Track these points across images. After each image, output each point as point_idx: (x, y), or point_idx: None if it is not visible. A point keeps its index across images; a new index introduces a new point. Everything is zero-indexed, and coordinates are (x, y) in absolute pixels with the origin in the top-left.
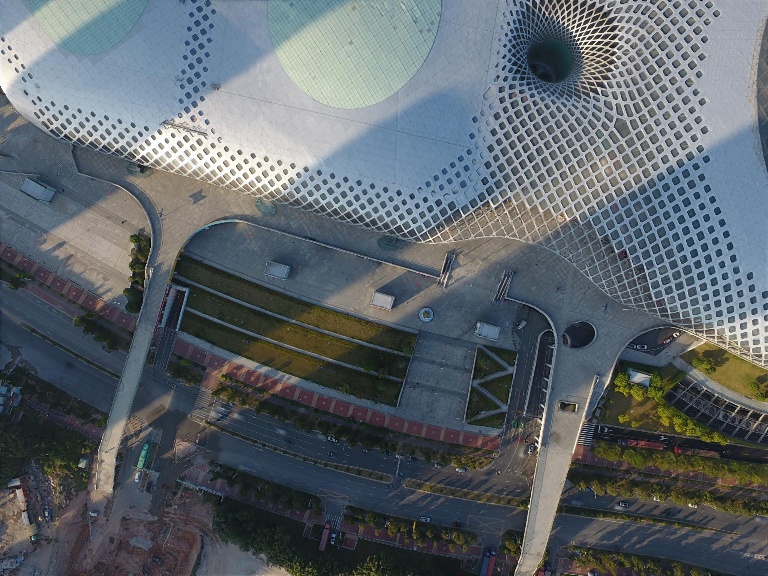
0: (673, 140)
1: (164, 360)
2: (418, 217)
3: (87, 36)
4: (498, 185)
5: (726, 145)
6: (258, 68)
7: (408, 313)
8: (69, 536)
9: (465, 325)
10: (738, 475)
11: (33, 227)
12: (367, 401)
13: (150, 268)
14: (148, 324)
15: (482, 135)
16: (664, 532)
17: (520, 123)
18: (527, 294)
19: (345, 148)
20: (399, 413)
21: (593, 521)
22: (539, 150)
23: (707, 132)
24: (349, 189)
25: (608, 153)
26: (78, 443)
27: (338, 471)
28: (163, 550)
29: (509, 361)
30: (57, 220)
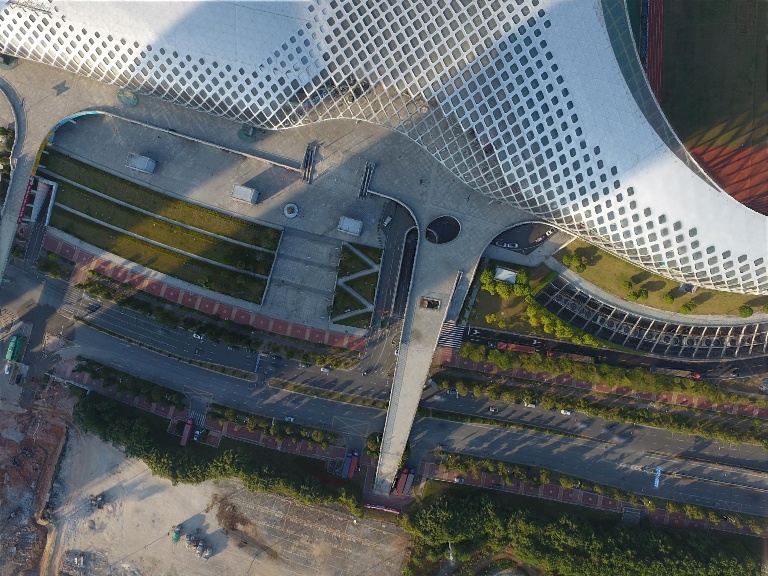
0: (514, 6)
1: (35, 255)
2: (264, 98)
3: None
4: (340, 61)
5: (567, 7)
6: None
7: (273, 209)
8: None
9: (330, 222)
10: (607, 377)
11: None
12: (232, 298)
13: (14, 159)
14: (12, 215)
15: (321, 7)
16: (535, 439)
17: None
18: (389, 187)
19: (185, 24)
20: (264, 311)
21: (461, 426)
22: (381, 23)
23: None
24: (193, 69)
25: (450, 23)
26: None
27: (203, 368)
28: (34, 443)
29: (375, 259)
30: None
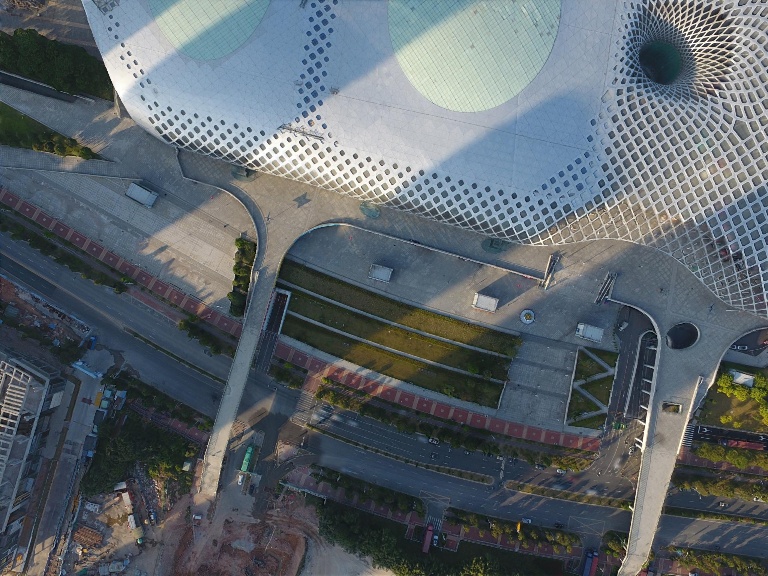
0: None
1: (265, 363)
2: (531, 220)
3: (208, 41)
4: (614, 187)
5: None
6: (377, 72)
7: (509, 315)
8: (173, 539)
9: (566, 327)
10: None
11: (135, 231)
12: (468, 403)
13: (256, 272)
14: (254, 328)
15: (600, 138)
16: (764, 532)
17: (638, 125)
18: (630, 296)
19: (462, 151)
20: (500, 415)
21: (693, 521)
22: (656, 152)
23: None
24: (464, 192)
25: (727, 155)
26: (182, 446)
27: (439, 473)
28: (265, 552)
29: (610, 362)
30: (159, 224)
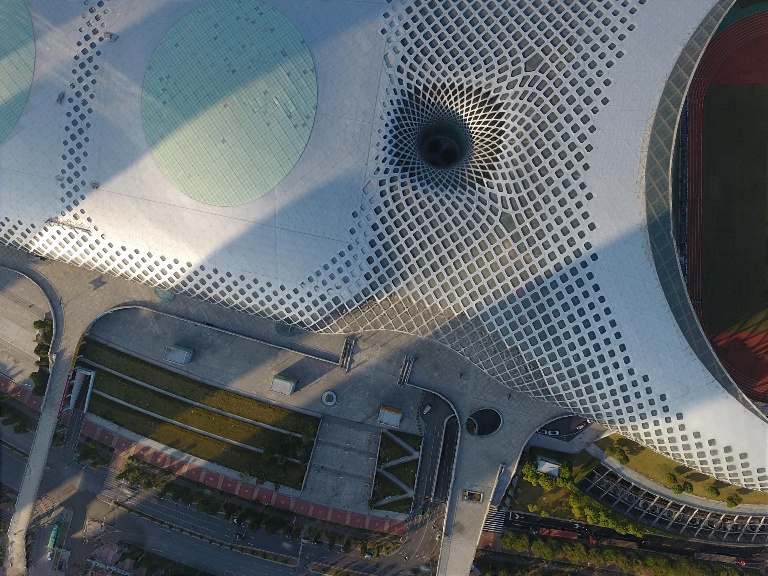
0: (560, 236)
1: (74, 441)
2: (304, 310)
3: None
4: (382, 280)
5: (614, 243)
6: (135, 166)
7: (311, 397)
8: None
9: (369, 409)
10: (653, 571)
11: None
12: (272, 484)
13: (53, 354)
14: (52, 409)
15: (363, 230)
16: None
17: (402, 217)
18: (429, 380)
19: (225, 244)
20: (304, 496)
21: None
22: (423, 244)
23: (594, 229)
24: (233, 283)
25: (494, 248)
26: None
27: (244, 553)
28: None
29: (415, 446)
30: None
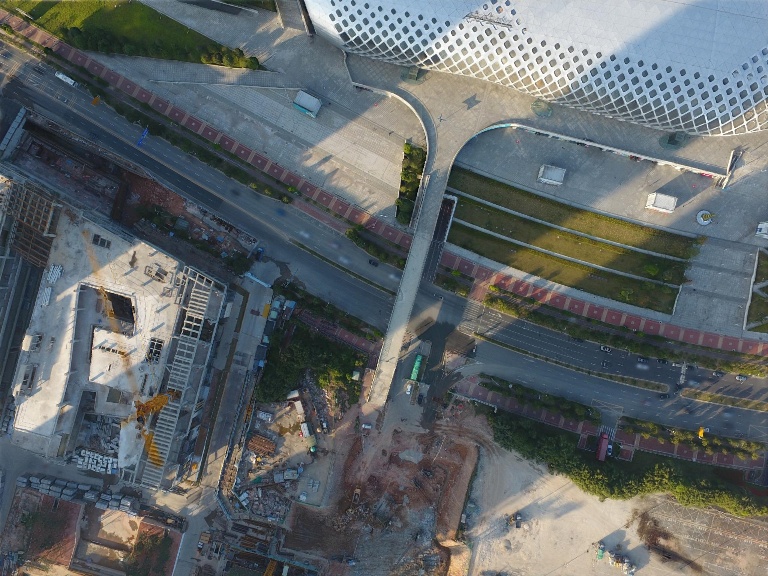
0: None
1: (431, 272)
2: (727, 104)
3: None
4: None
5: None
6: None
7: (684, 217)
8: (344, 448)
9: (745, 227)
10: None
11: (299, 142)
12: (641, 309)
13: (426, 176)
14: (425, 232)
15: None
16: None
17: None
18: None
19: (659, 32)
20: (674, 321)
21: None
22: None
23: None
24: (656, 77)
25: None
26: (351, 356)
27: (612, 381)
28: (433, 463)
29: None
30: (323, 134)
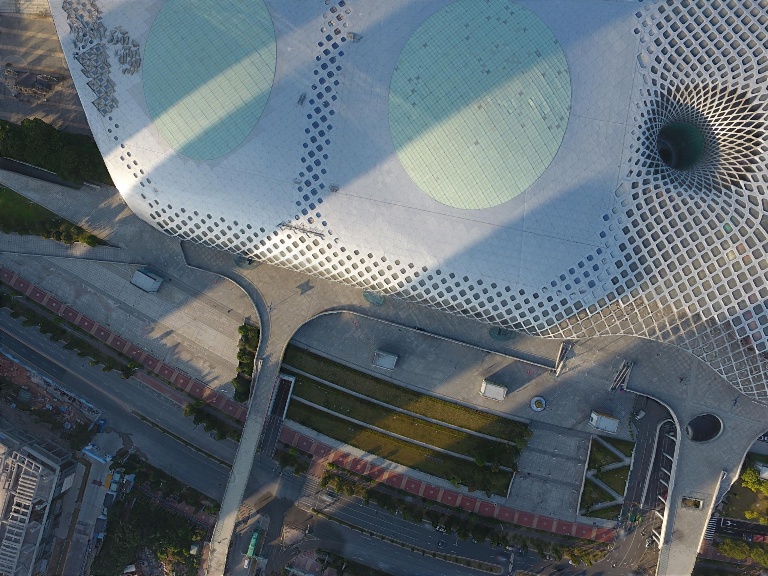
0: None
1: (270, 447)
2: (540, 315)
3: (206, 141)
4: (629, 284)
5: None
6: (378, 169)
7: (519, 402)
8: None
9: (579, 414)
10: None
11: (141, 316)
12: (476, 491)
13: (259, 360)
14: (258, 416)
15: (613, 233)
16: None
17: (654, 220)
18: (648, 385)
19: (467, 248)
20: (509, 503)
21: None
22: (675, 248)
23: None
24: (469, 288)
25: (752, 252)
26: (189, 530)
27: (447, 561)
28: None
29: (626, 452)
30: (164, 309)
